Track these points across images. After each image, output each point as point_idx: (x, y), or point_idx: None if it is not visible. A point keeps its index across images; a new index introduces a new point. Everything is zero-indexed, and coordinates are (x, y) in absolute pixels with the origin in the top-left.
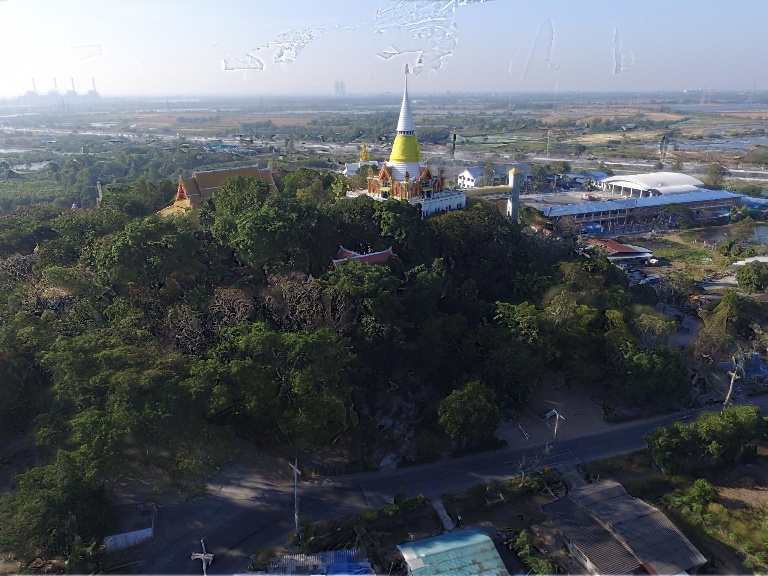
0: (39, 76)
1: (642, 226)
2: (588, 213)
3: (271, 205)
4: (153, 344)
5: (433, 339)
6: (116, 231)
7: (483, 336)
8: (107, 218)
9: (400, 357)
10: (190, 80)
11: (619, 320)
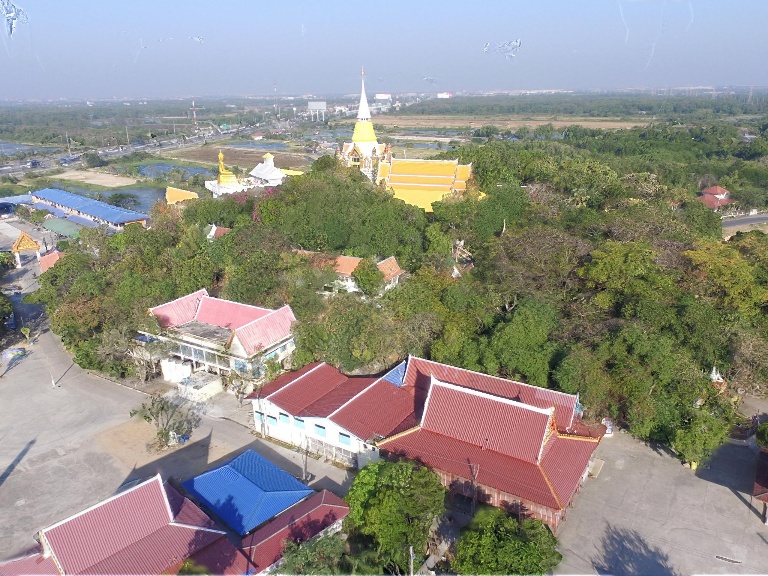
0: (301, 37)
1: None
2: None
3: None
4: None
5: None
6: None
7: None
8: None
9: None
10: None
11: None
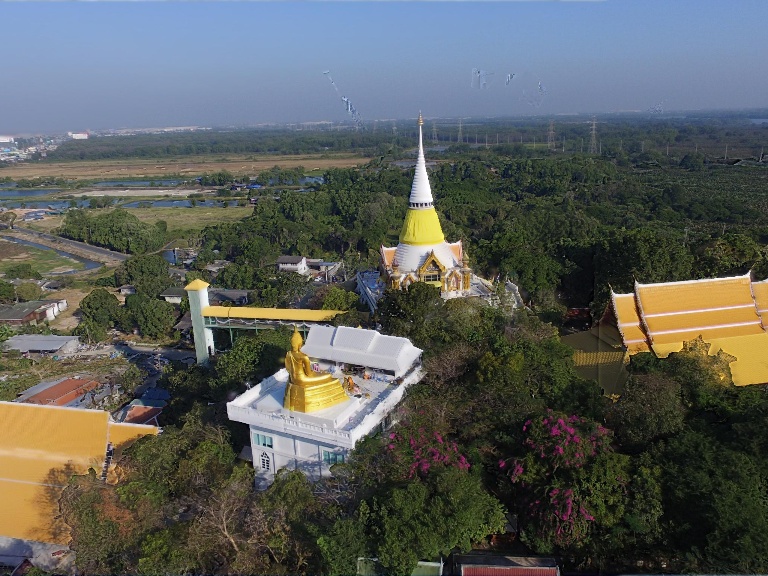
0: None
1: None
2: None
3: None
4: None
5: None
6: None
7: None
8: None
9: None
10: None
11: None
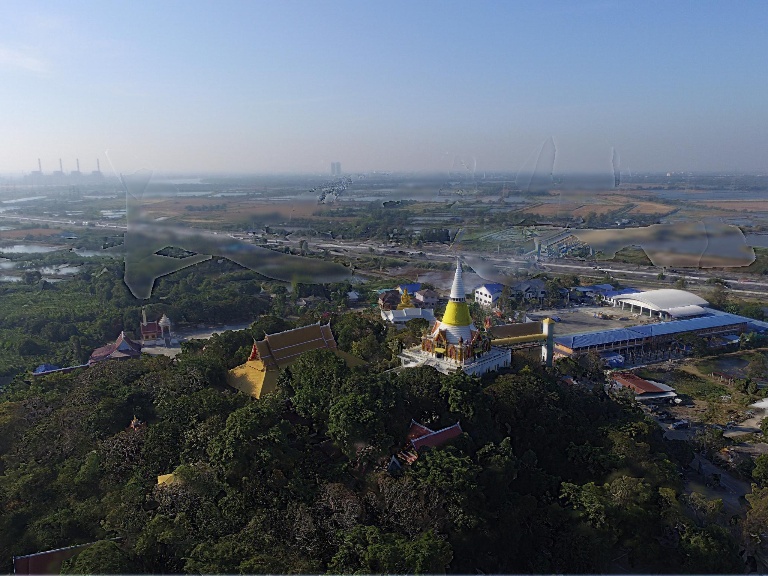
0: None
1: (659, 355)
2: (608, 343)
3: (352, 385)
4: (279, 550)
5: (513, 527)
6: (217, 414)
7: (552, 517)
8: (207, 400)
9: (485, 545)
10: (242, 224)
11: (672, 499)
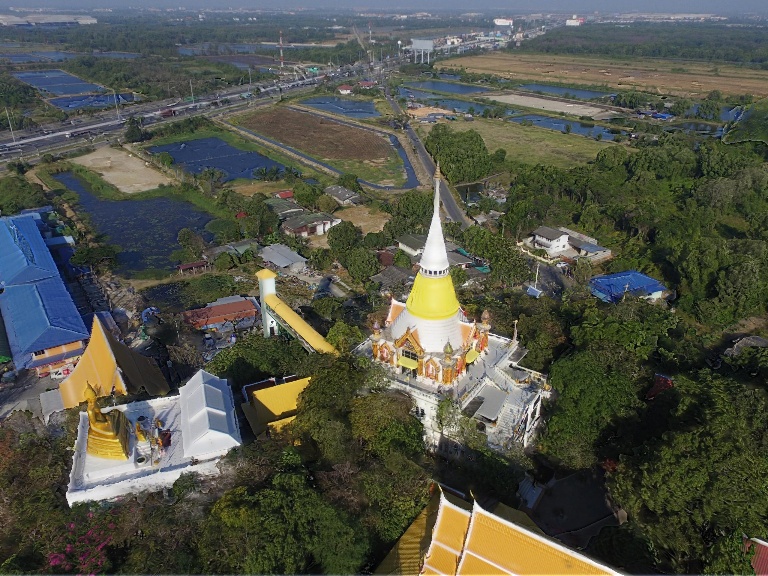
0: None
1: None
2: None
3: None
4: None
5: None
6: None
7: None
8: None
9: None
10: None
11: None
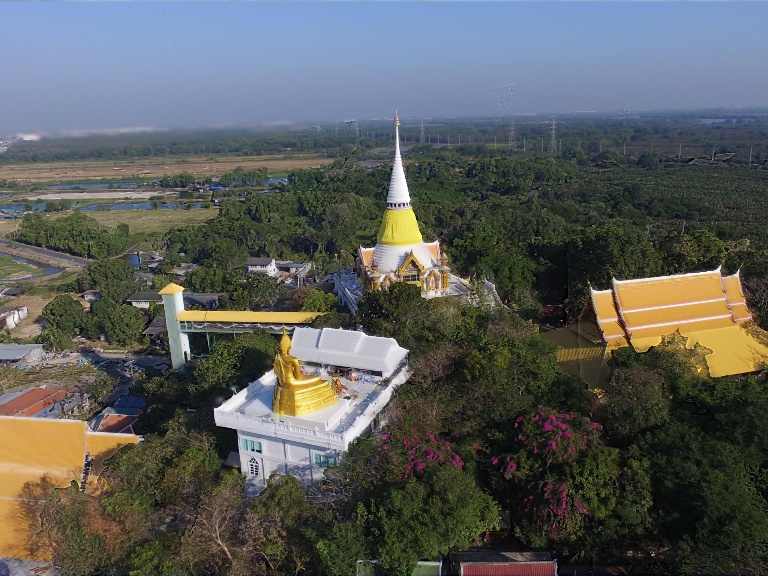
0: None
1: None
2: None
3: None
4: None
5: None
6: None
7: None
8: None
9: None
10: None
11: None
